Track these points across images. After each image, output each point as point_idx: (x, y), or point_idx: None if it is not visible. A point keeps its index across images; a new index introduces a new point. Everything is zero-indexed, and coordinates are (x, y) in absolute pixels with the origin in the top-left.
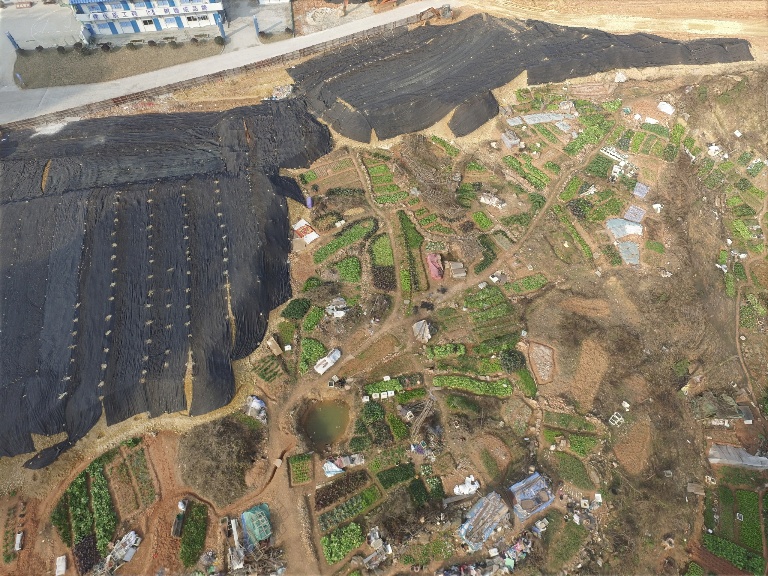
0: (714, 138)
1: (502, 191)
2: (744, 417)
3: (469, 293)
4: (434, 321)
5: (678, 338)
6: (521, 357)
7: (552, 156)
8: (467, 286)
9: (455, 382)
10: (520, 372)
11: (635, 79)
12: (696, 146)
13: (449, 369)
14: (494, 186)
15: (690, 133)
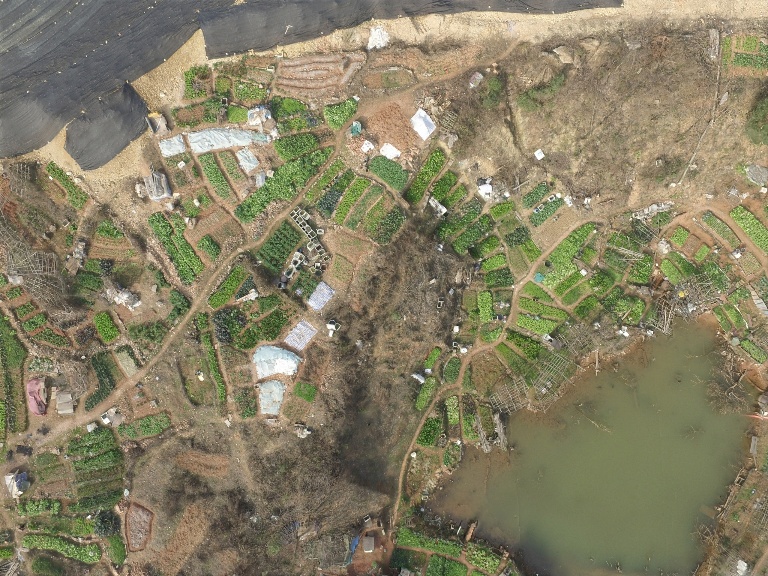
0: (494, 168)
1: (140, 278)
2: (364, 548)
3: (76, 434)
4: (31, 470)
5: (294, 504)
6: (113, 525)
7: (215, 224)
8: (75, 425)
9: (44, 544)
10: (111, 539)
11: (403, 42)
12: (462, 182)
13: (40, 528)
14: (130, 269)
15: (456, 163)
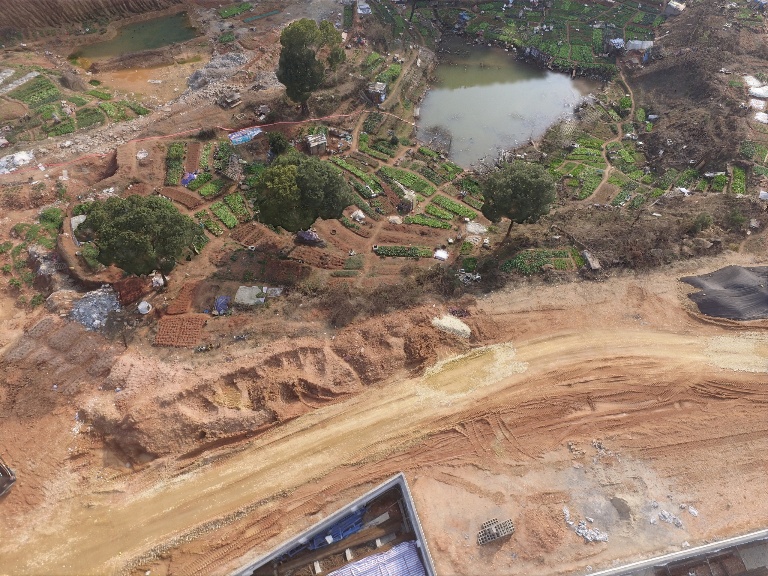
0: None
1: None
2: None
3: None
4: None
5: None
6: None
7: None
8: None
9: None
10: None
11: None
12: None
13: None
14: None
15: None
